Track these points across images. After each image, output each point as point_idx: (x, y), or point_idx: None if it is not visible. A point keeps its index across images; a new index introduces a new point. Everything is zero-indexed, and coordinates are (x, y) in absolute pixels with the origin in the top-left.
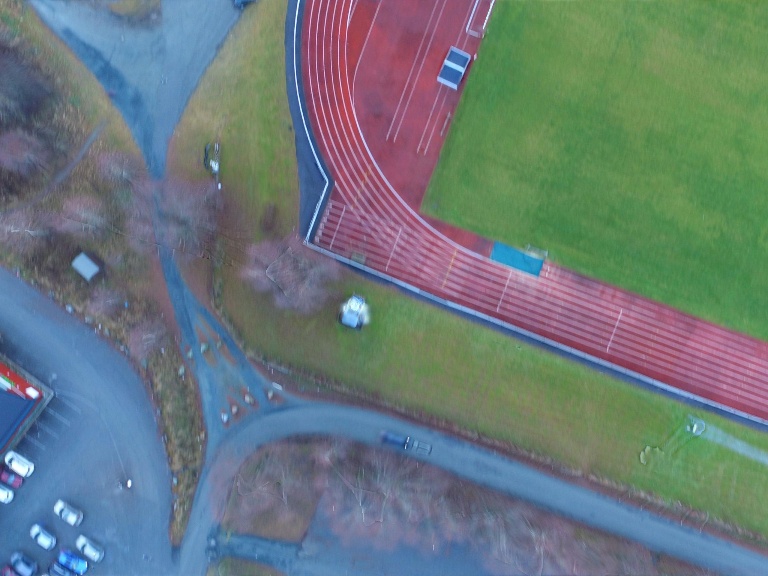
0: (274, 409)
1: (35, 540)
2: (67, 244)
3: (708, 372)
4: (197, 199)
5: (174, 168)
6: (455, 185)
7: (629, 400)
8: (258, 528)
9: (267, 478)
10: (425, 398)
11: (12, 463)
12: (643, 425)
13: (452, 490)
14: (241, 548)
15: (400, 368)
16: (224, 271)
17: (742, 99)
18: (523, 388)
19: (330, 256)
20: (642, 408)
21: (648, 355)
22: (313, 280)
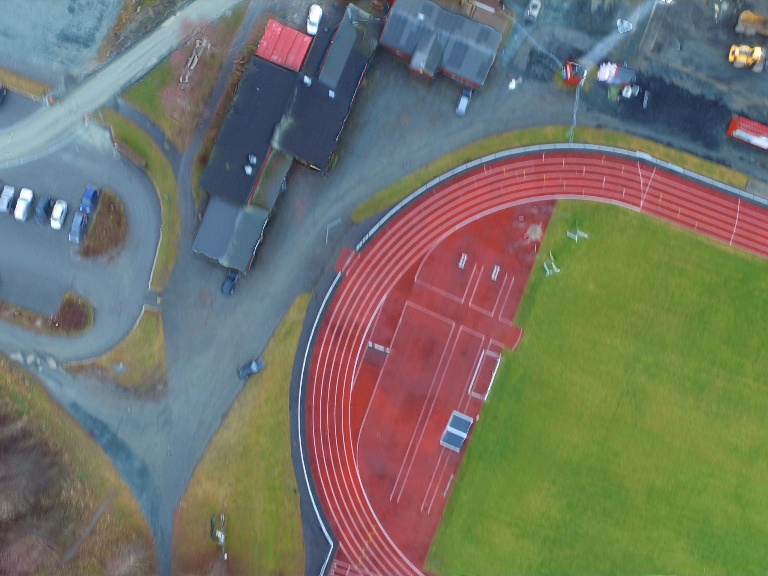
0: None
1: None
2: None
3: None
4: (204, 575)
5: (181, 540)
6: (458, 543)
7: None
8: None
9: None
10: None
11: None
12: None
13: None
14: None
15: None
16: None
17: (742, 454)
18: None
19: None
20: None
21: None
22: None
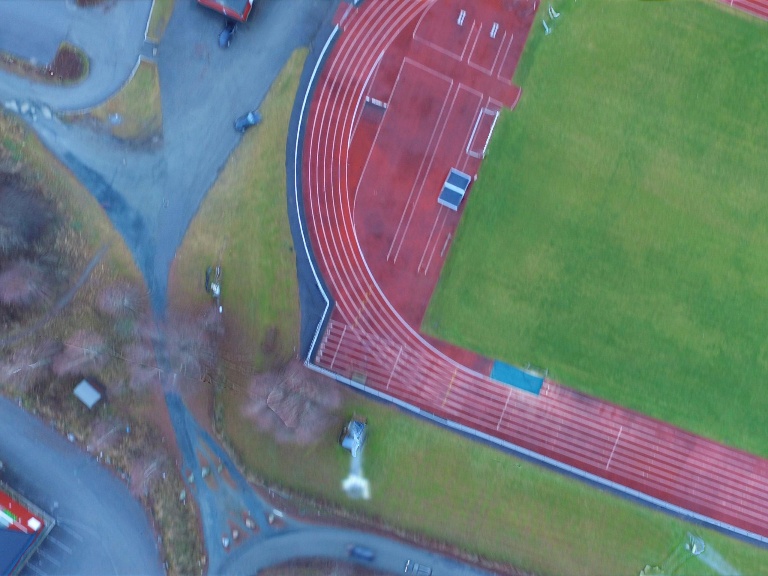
0: (275, 533)
1: None
2: (69, 370)
3: (707, 489)
4: (198, 324)
5: (175, 292)
6: (455, 305)
7: (629, 518)
8: None
9: None
10: (425, 520)
11: None
12: (643, 543)
13: None
14: None
15: (400, 490)
16: (225, 395)
17: (741, 218)
18: (523, 508)
19: (331, 377)
20: (642, 526)
21: (648, 472)
22: (314, 402)
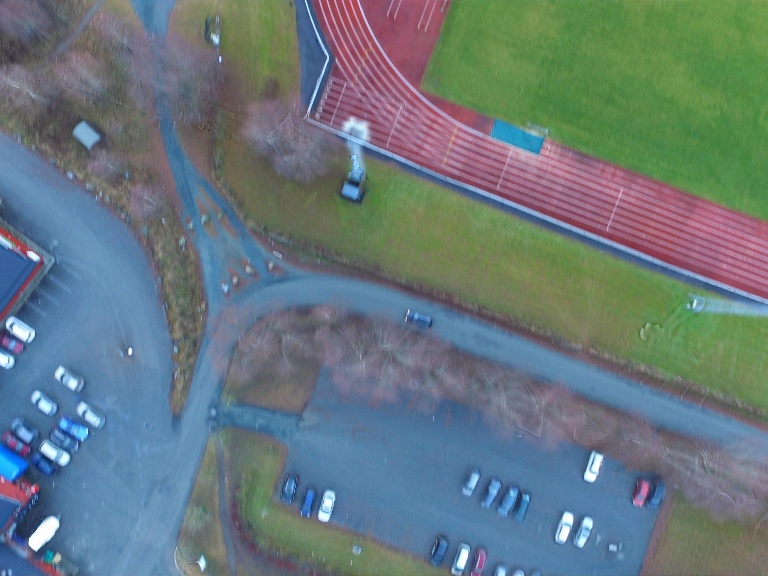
0: (275, 280)
1: (36, 405)
2: (68, 114)
3: (708, 251)
4: (198, 70)
5: (175, 41)
6: (455, 62)
7: (629, 278)
8: (259, 398)
9: (268, 342)
10: (425, 271)
11: (13, 327)
12: (643, 302)
13: (452, 362)
14: (242, 418)
15: (400, 242)
16: (225, 143)
17: None
18: (523, 264)
19: (331, 131)
20: (642, 286)
21: (648, 234)
22: (314, 154)
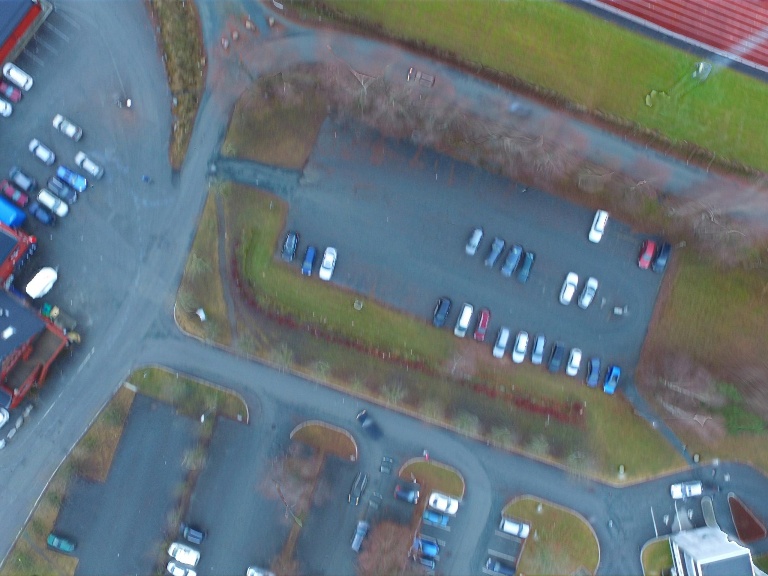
0: (275, 36)
1: (34, 153)
2: None
3: (714, 22)
4: None
5: None
6: None
7: (634, 47)
8: (259, 153)
9: None
10: (428, 31)
11: (10, 71)
12: (649, 71)
13: (455, 120)
14: (242, 173)
15: (403, 3)
16: None
17: None
18: (527, 30)
19: None
20: (648, 55)
21: (654, 4)
22: None
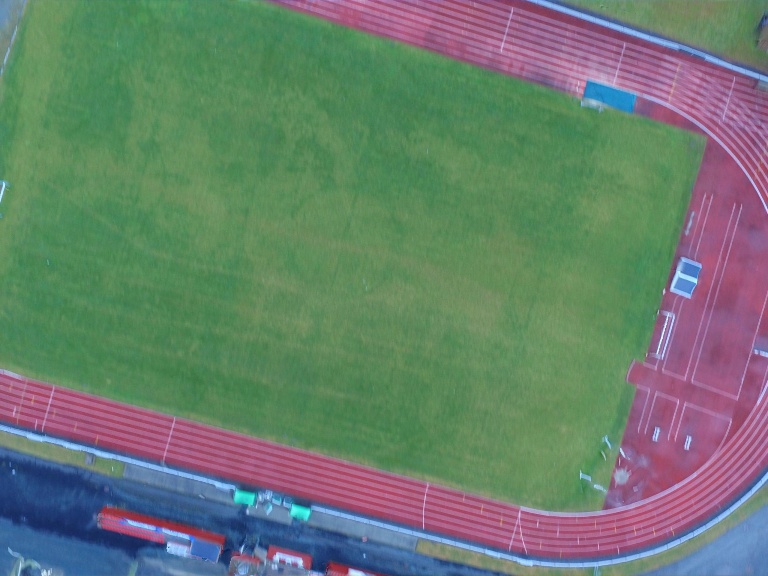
0: None
1: None
2: None
3: None
4: None
5: None
6: (676, 166)
7: None
8: None
9: None
10: None
11: None
12: None
13: None
14: None
15: None
16: None
17: (400, 274)
18: None
19: None
20: None
21: (472, 7)
22: None
